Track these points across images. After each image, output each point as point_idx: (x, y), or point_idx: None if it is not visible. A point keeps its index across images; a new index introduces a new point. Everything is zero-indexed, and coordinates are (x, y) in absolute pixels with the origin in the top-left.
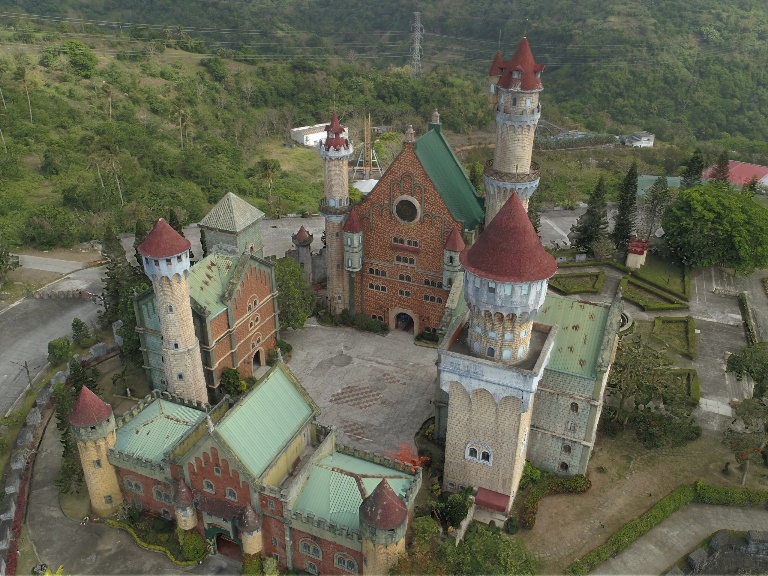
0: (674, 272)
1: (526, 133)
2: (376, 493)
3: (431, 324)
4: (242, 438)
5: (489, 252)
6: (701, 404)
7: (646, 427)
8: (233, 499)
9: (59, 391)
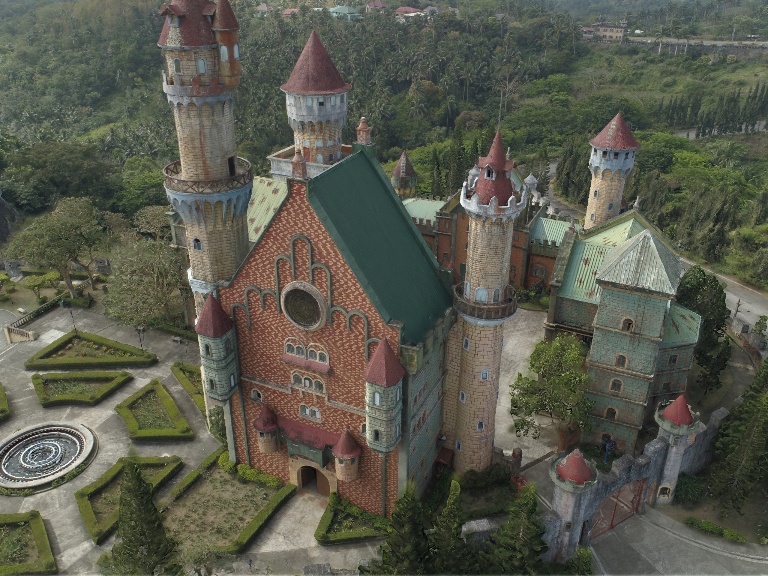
0: None
1: None
2: None
3: None
4: None
5: None
6: None
7: None
8: None
9: None
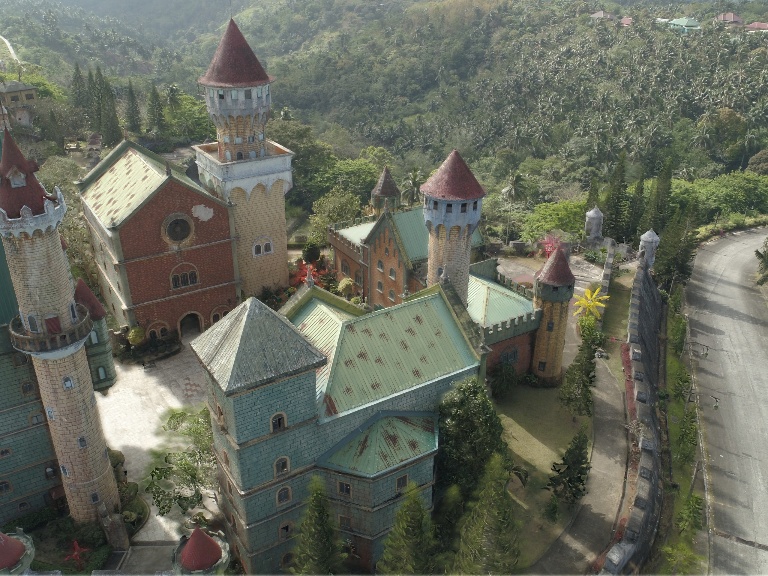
0: None
1: None
2: None
3: None
4: None
5: None
6: None
7: None
8: None
9: None
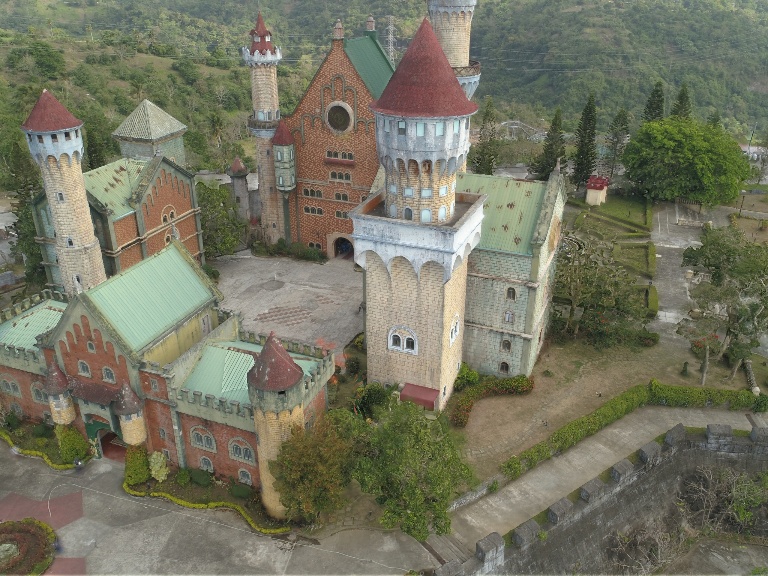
0: (636, 208)
1: (461, 21)
2: (263, 350)
3: None
4: (120, 308)
5: (398, 88)
6: (660, 316)
7: (595, 326)
8: (111, 381)
9: None
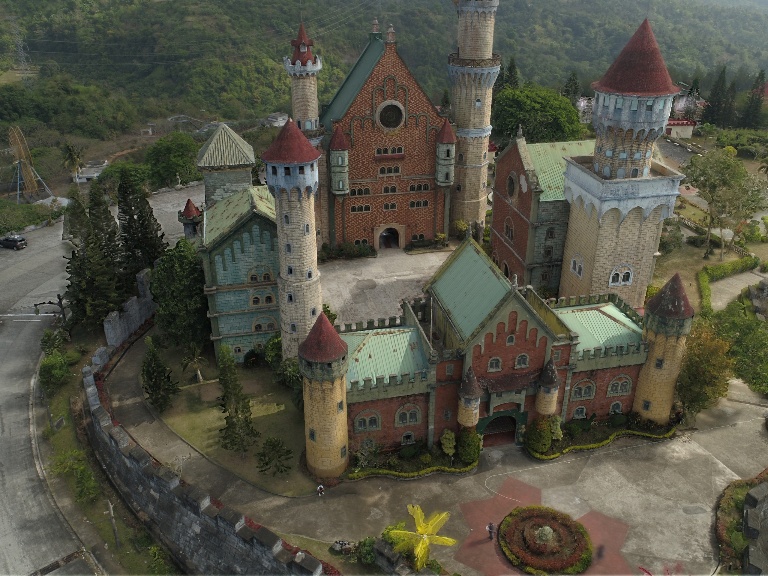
0: None
1: (492, 19)
2: (674, 289)
3: (418, 231)
4: None
5: (641, 75)
6: None
7: None
8: (524, 366)
9: (228, 357)
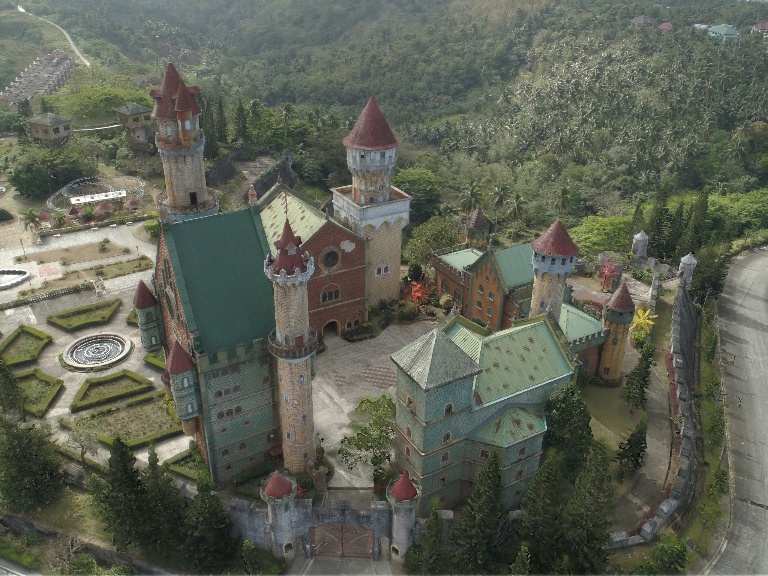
0: None
1: None
2: None
3: None
4: None
5: None
6: None
7: None
8: None
9: None
